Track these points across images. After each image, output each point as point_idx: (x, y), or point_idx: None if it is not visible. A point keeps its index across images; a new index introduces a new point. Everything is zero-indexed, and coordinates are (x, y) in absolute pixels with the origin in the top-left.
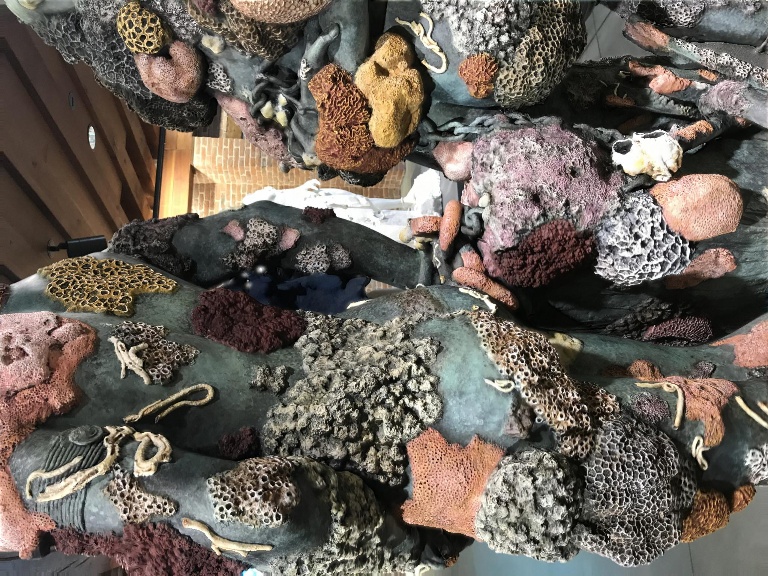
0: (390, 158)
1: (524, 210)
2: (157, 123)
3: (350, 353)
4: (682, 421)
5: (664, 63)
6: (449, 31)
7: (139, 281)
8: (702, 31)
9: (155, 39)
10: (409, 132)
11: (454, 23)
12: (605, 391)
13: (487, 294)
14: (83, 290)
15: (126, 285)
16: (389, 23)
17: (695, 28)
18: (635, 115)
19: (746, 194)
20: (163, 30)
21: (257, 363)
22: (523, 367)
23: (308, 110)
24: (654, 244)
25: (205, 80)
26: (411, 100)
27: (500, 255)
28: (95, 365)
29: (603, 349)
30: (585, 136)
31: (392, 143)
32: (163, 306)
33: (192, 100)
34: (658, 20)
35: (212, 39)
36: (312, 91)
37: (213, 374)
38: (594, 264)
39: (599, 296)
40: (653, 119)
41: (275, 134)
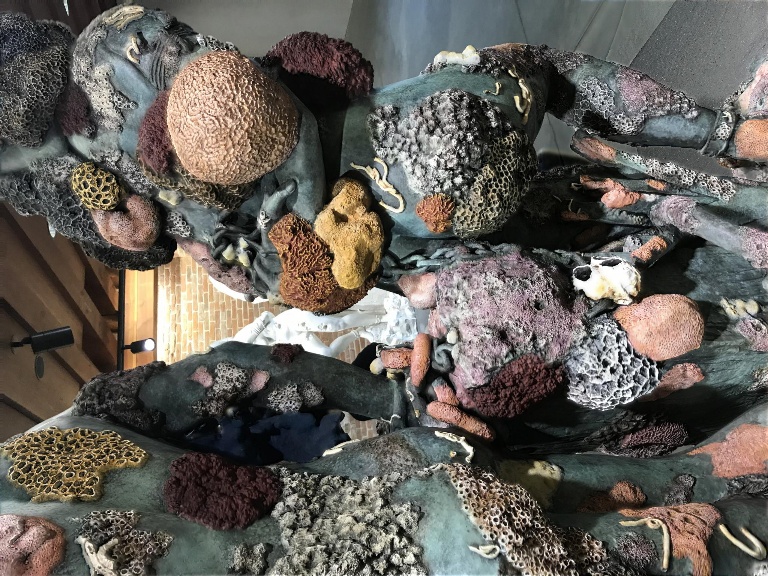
0: (355, 295)
1: (492, 348)
2: (118, 266)
3: (329, 523)
4: (670, 561)
5: (613, 171)
6: (404, 174)
7: (106, 456)
8: (645, 138)
9: (111, 197)
10: (372, 270)
11: (408, 168)
12: (591, 537)
13: (463, 429)
14: (47, 473)
15: (92, 463)
16: (344, 168)
17: (638, 136)
18: (590, 226)
19: (705, 307)
20: (119, 187)
21: (234, 543)
22: (507, 530)
23: (270, 253)
24: (623, 369)
25: (164, 227)
26: (372, 243)
27: (473, 390)
28: (62, 575)
29: (584, 474)
30: (545, 260)
31: (356, 285)
32: (132, 482)
33: (152, 245)
34: (603, 130)
35: (169, 193)
36: (273, 241)
37: (188, 564)
38: (566, 391)
39: (574, 414)
40: (608, 228)
41: (238, 270)
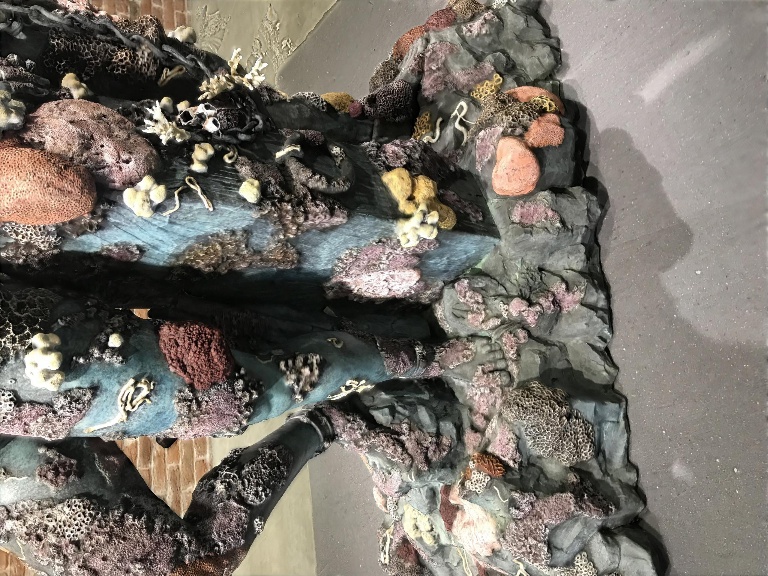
0: None
1: None
2: None
3: None
4: None
5: None
6: None
7: None
8: None
9: None
10: None
11: None
12: None
13: None
14: None
15: None
16: None
17: None
18: None
19: None
20: None
21: None
22: None
23: None
24: None
25: None
26: None
27: None
28: None
29: None
30: None
31: None
32: None
33: None
34: None
35: None
36: None
37: None
38: None
39: None
40: None
41: None
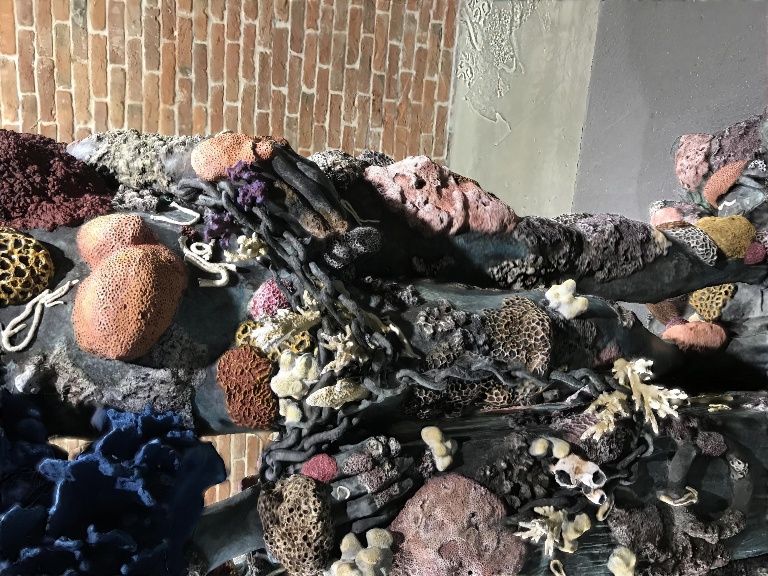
0: None
1: None
2: None
3: None
4: None
5: None
6: None
7: None
8: None
9: None
10: None
11: None
12: None
13: None
14: None
15: None
16: None
17: None
18: None
19: None
20: None
21: None
22: None
23: None
24: None
25: None
26: None
27: None
28: None
29: None
30: None
31: None
32: None
33: None
34: None
35: None
36: None
37: None
38: None
39: None
40: None
41: None
